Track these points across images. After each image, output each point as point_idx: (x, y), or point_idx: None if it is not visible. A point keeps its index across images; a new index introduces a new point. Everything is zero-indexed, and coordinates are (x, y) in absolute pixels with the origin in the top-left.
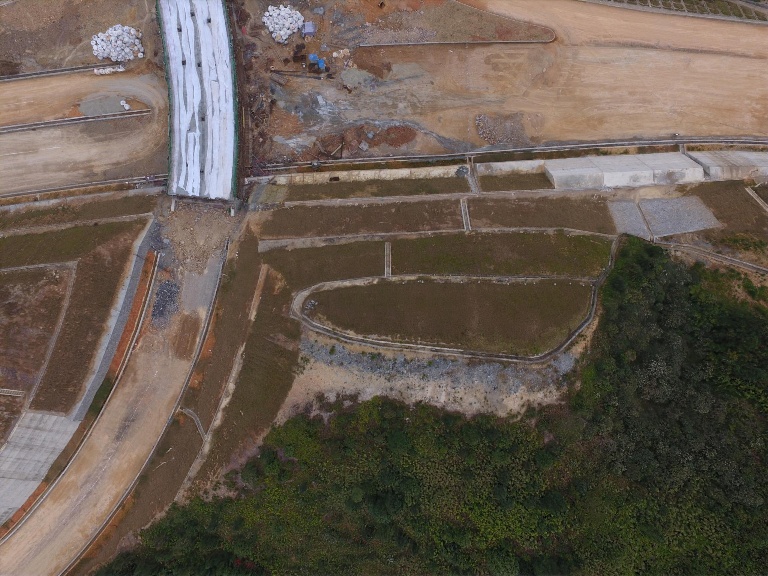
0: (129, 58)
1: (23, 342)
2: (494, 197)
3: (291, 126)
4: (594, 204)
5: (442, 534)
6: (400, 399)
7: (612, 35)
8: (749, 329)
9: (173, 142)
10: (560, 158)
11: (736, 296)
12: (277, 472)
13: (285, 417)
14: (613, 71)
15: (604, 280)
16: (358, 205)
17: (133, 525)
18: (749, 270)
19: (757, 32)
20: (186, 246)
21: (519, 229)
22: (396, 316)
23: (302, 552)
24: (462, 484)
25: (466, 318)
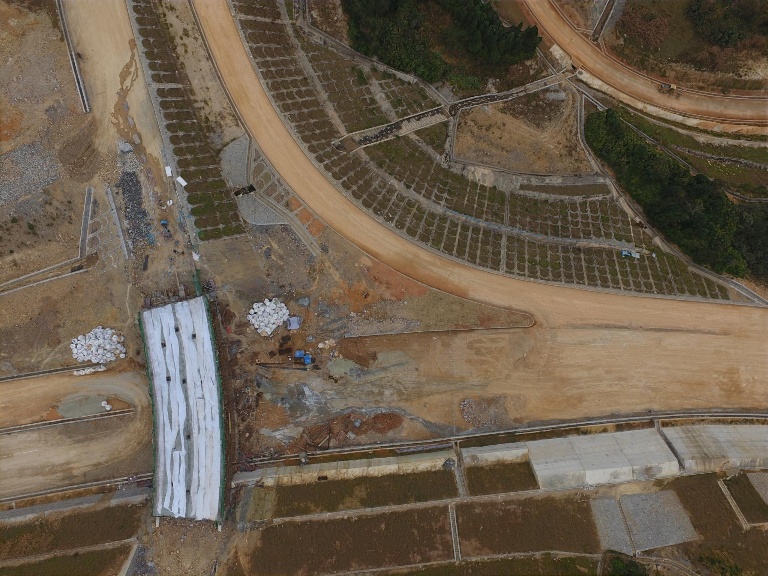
0: (110, 359)
1: None
2: (481, 501)
3: (278, 418)
4: (578, 504)
5: None
6: None
7: (588, 318)
8: None
9: (158, 461)
10: (543, 439)
11: None
12: None
13: None
14: (590, 352)
15: None
16: (348, 518)
17: None
18: None
19: (721, 311)
20: (172, 571)
21: (508, 556)
22: None
23: None
24: None
25: None
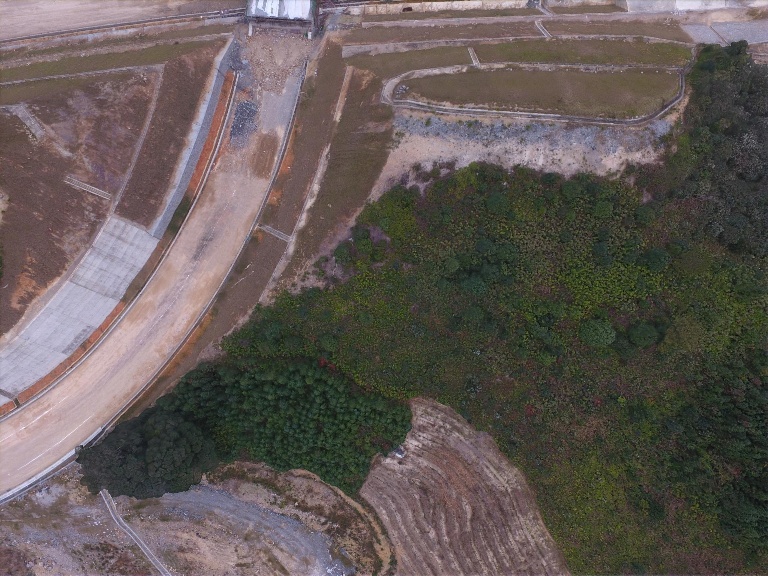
0: None
1: (112, 139)
2: (568, 20)
3: None
4: (667, 26)
5: (535, 309)
6: (498, 164)
7: None
8: None
9: None
10: None
11: None
12: (370, 252)
13: (380, 192)
14: None
15: (690, 69)
16: (434, 26)
17: (214, 336)
18: None
19: None
20: (265, 65)
21: (599, 36)
22: (490, 91)
23: (386, 352)
24: (559, 250)
25: (560, 92)
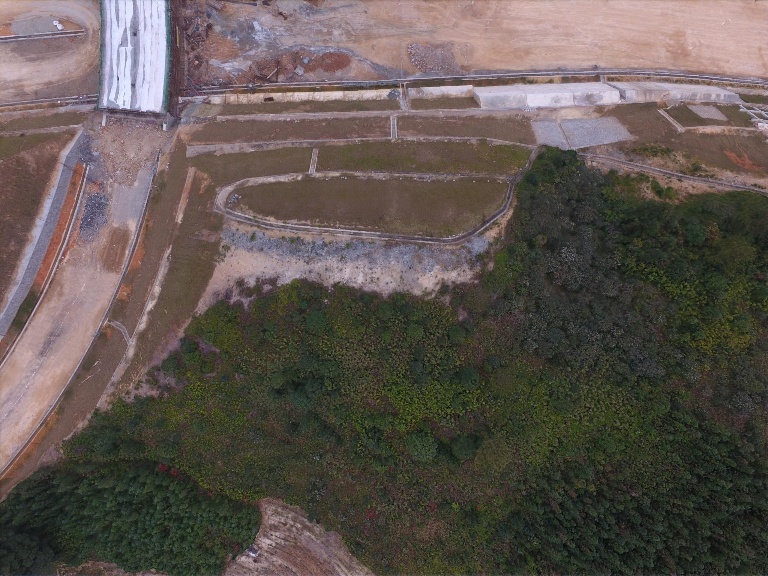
0: None
1: None
2: (423, 115)
3: (227, 50)
4: (518, 123)
5: (364, 421)
6: (319, 281)
7: None
8: (651, 216)
9: (104, 56)
10: (489, 86)
11: (645, 196)
12: (199, 364)
13: (206, 305)
14: (537, 6)
15: (520, 178)
16: (290, 120)
17: (55, 438)
18: (657, 174)
19: None
20: (116, 158)
21: (443, 138)
22: (317, 205)
23: (229, 456)
24: (381, 365)
25: (385, 206)
